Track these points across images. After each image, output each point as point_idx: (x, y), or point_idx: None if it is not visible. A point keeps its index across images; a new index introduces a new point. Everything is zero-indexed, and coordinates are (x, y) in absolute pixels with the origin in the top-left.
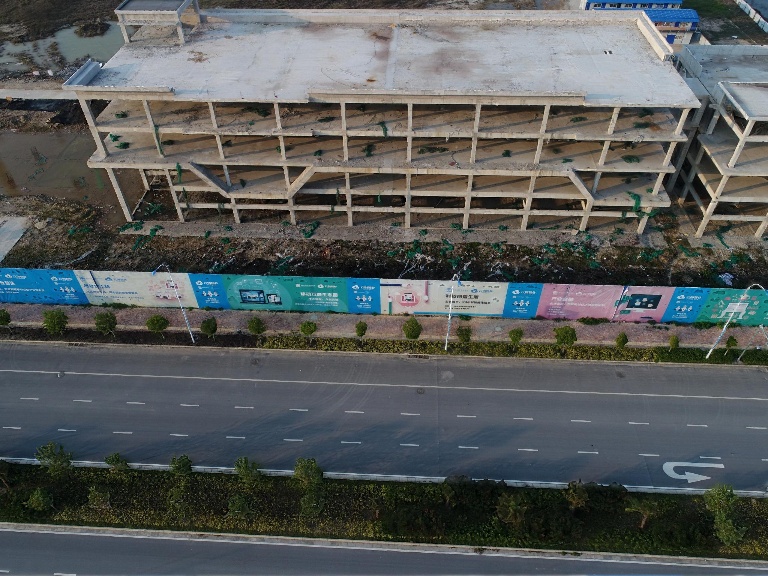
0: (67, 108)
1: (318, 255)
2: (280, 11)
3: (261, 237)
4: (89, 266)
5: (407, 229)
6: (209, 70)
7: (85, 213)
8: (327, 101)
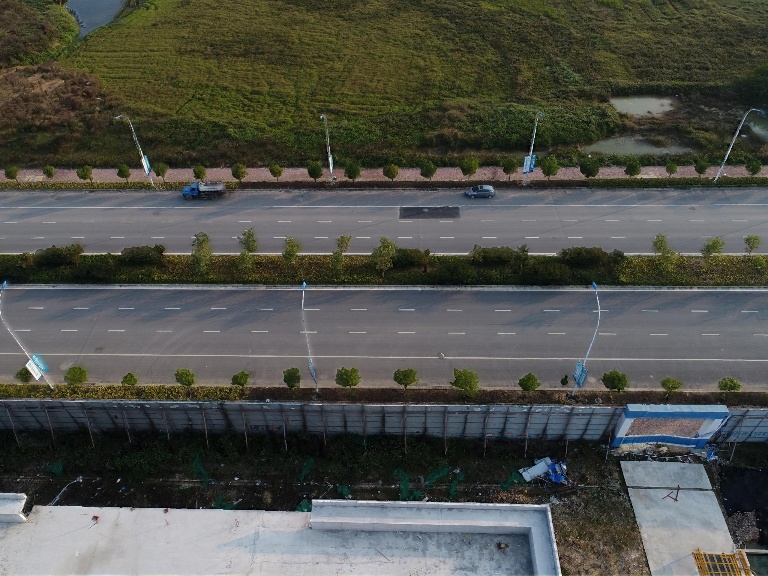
0: None
1: None
2: None
3: None
4: None
5: None
6: None
7: None
8: None
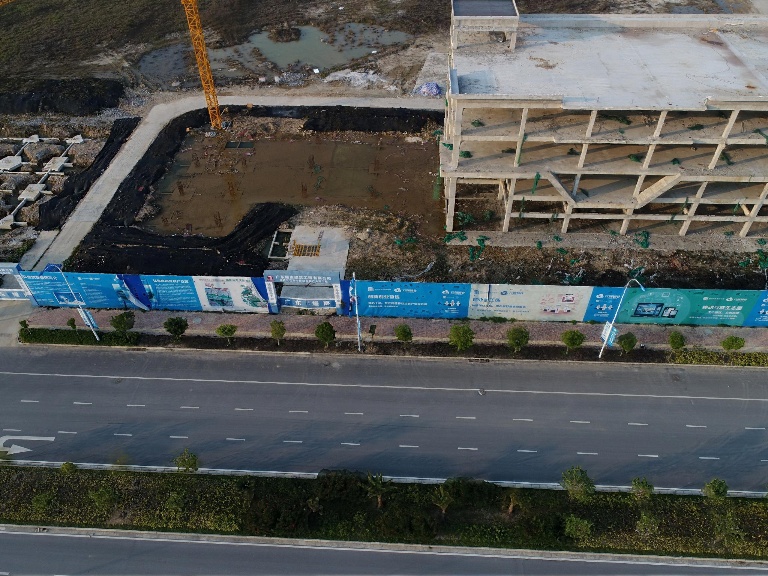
0: (316, 115)
1: (667, 266)
2: (591, 16)
3: (597, 247)
4: (441, 278)
5: (742, 238)
6: (570, 77)
7: (399, 223)
8: (722, 109)
